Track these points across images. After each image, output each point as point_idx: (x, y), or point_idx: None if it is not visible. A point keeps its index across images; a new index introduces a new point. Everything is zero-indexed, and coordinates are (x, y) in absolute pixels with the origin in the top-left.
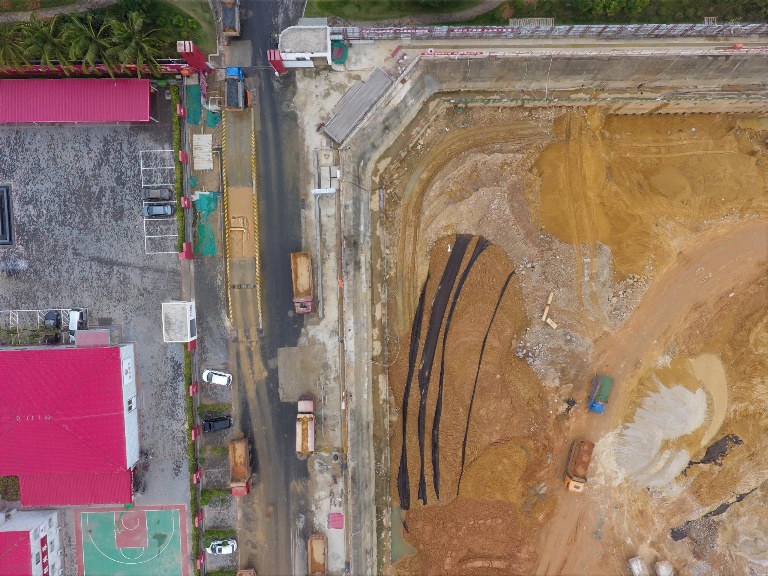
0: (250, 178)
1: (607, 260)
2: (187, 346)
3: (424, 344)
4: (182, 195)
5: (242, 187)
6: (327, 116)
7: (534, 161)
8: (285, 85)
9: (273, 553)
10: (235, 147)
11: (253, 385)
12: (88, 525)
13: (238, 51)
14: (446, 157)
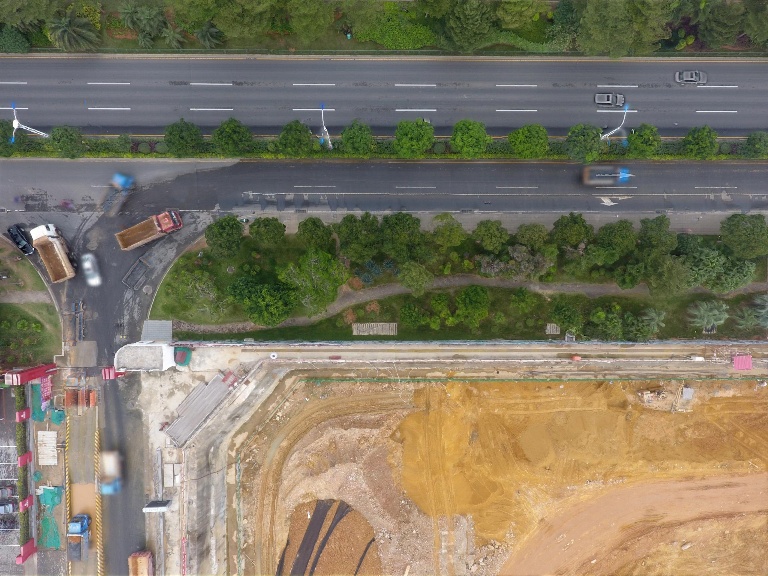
0: (93, 475)
1: (465, 533)
2: None
3: None
4: (25, 491)
5: (86, 484)
6: (171, 415)
7: (396, 427)
8: (130, 384)
9: None
10: (78, 446)
11: None
12: None
13: (84, 351)
14: (306, 426)
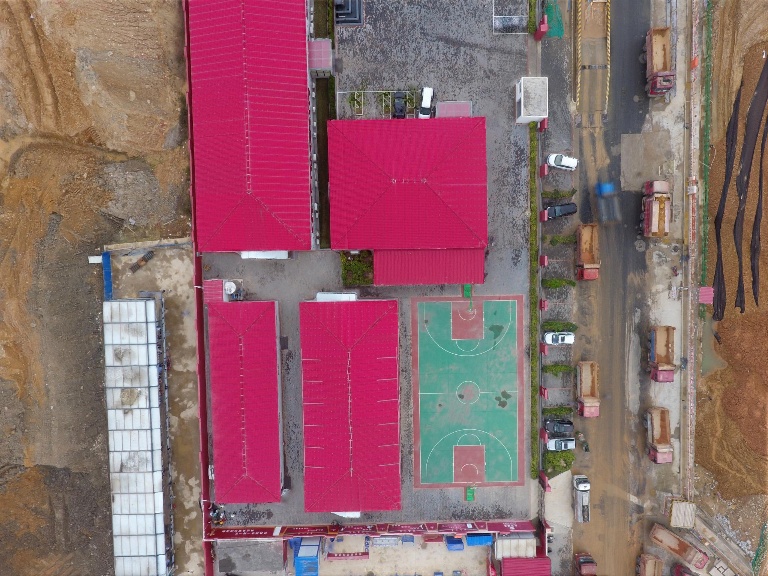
0: None
1: None
2: (544, 122)
3: (741, 149)
4: None
5: None
6: None
7: None
8: None
9: (607, 348)
10: None
11: (595, 173)
12: (424, 315)
13: None
14: None
